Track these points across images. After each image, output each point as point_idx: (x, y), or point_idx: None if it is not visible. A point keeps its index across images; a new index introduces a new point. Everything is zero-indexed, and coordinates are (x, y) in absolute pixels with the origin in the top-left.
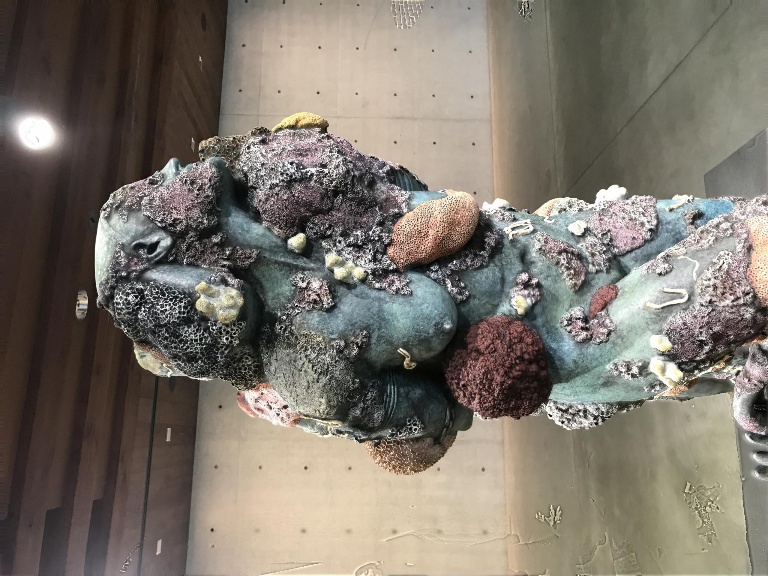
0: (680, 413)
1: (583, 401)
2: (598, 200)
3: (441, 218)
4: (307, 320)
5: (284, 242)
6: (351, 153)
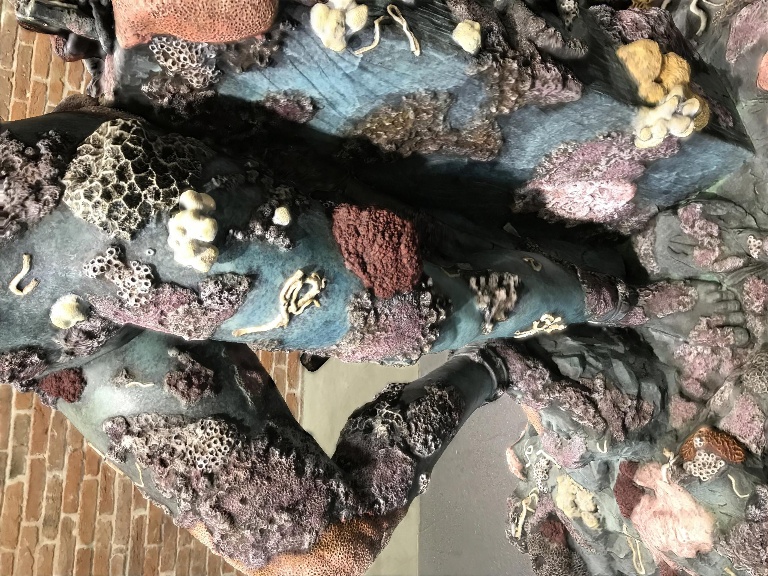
0: None
1: None
2: (181, 206)
3: None
4: None
5: None
6: None
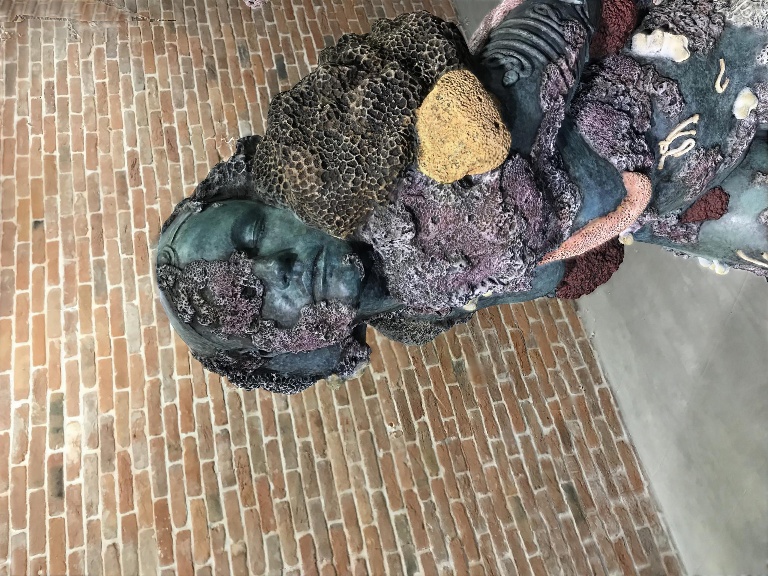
0: None
1: None
2: None
3: (602, 242)
4: None
5: None
6: (535, 226)
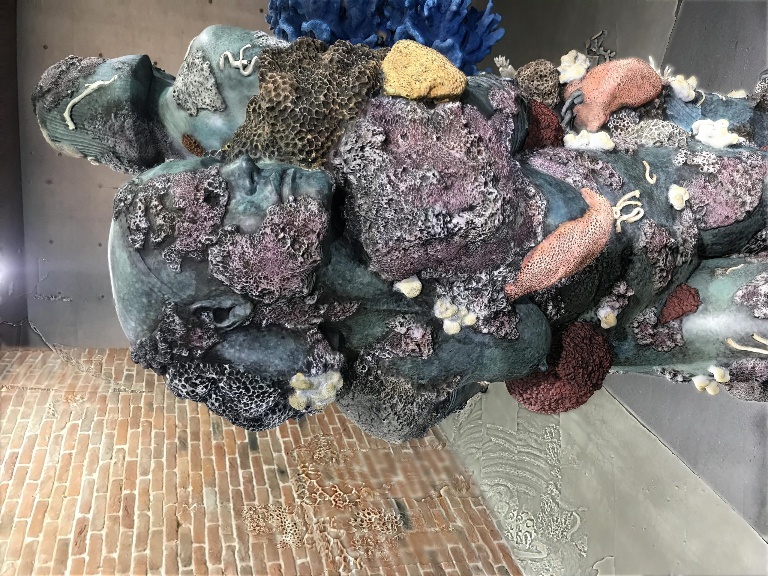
0: None
1: None
2: (697, 127)
3: (578, 253)
4: (398, 366)
5: (390, 285)
6: (503, 168)
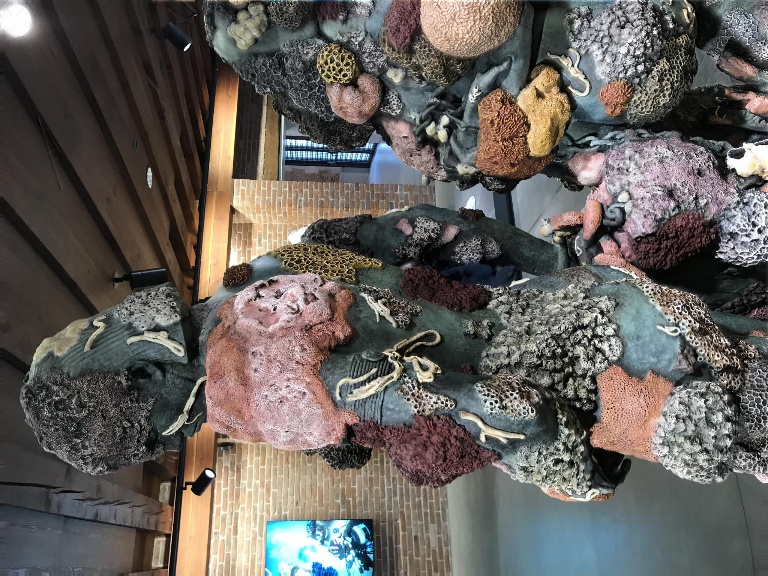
0: None
1: (613, 1)
2: None
3: None
4: None
5: None
6: None
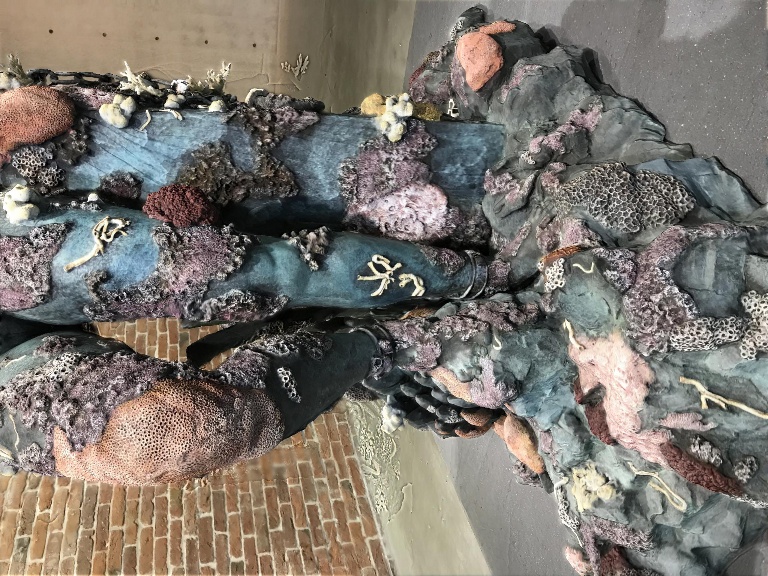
0: (391, 43)
1: None
2: None
3: None
4: None
5: None
6: None
